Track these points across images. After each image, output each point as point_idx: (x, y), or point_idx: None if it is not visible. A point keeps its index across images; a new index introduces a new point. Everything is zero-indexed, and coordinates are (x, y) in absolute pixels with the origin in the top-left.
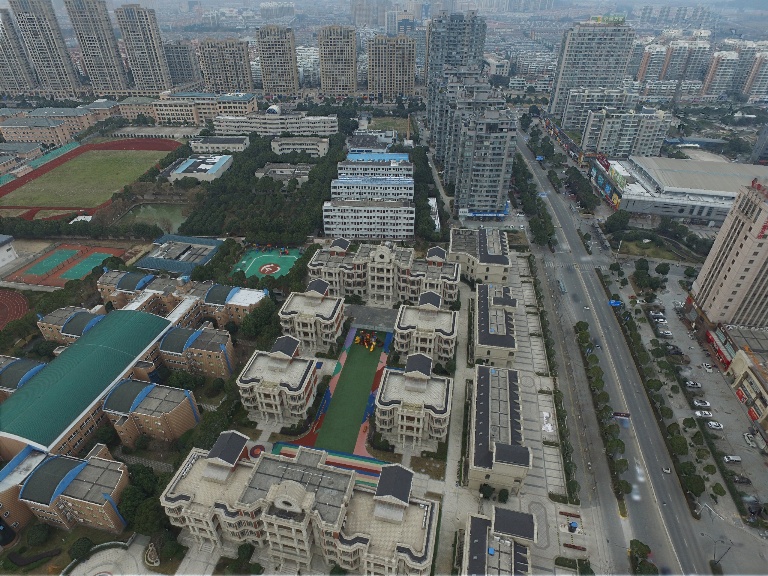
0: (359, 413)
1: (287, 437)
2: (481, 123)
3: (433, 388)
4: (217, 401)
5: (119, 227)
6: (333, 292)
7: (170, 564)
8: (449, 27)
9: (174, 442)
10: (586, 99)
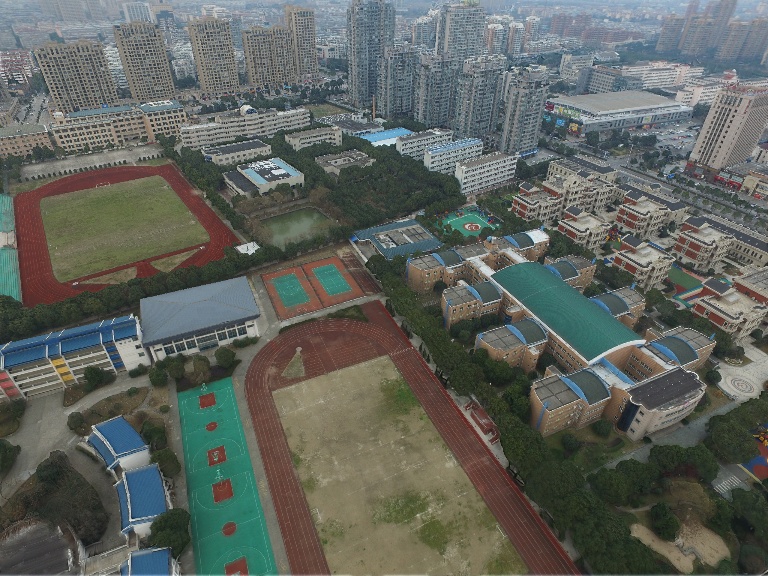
0: (673, 268)
1: (672, 292)
2: (532, 82)
3: None
4: None
5: (308, 239)
6: (542, 223)
7: (744, 359)
8: (368, 14)
9: (641, 322)
10: None
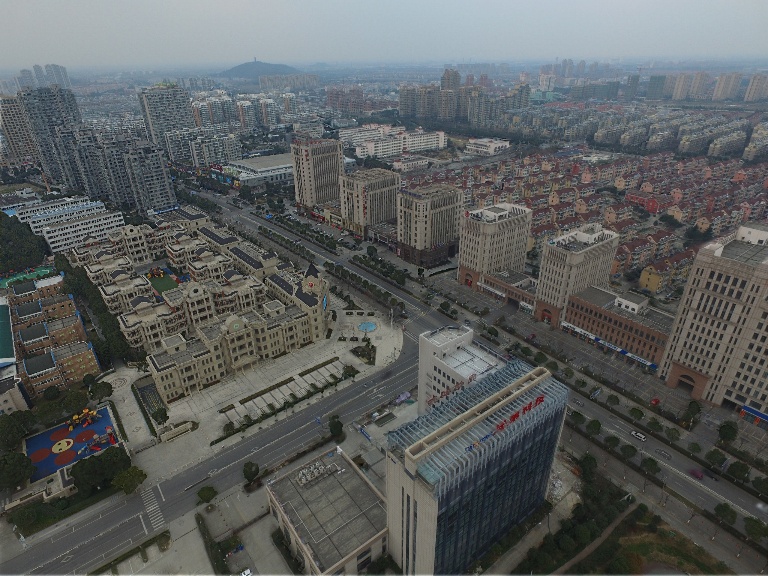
0: None
1: None
2: (138, 149)
3: (217, 258)
4: (88, 327)
5: None
6: None
7: None
8: (40, 98)
9: None
10: (180, 137)
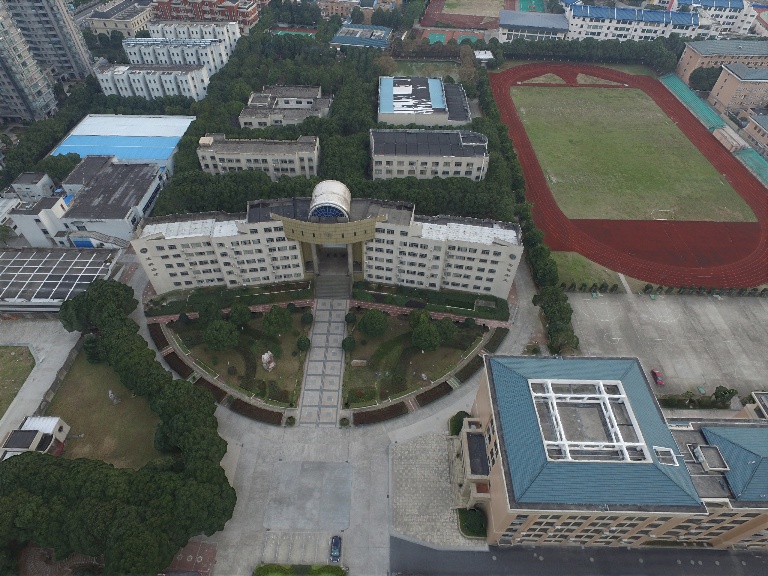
0: None
1: None
2: None
3: None
4: None
5: None
6: None
7: None
8: None
9: None
10: None
